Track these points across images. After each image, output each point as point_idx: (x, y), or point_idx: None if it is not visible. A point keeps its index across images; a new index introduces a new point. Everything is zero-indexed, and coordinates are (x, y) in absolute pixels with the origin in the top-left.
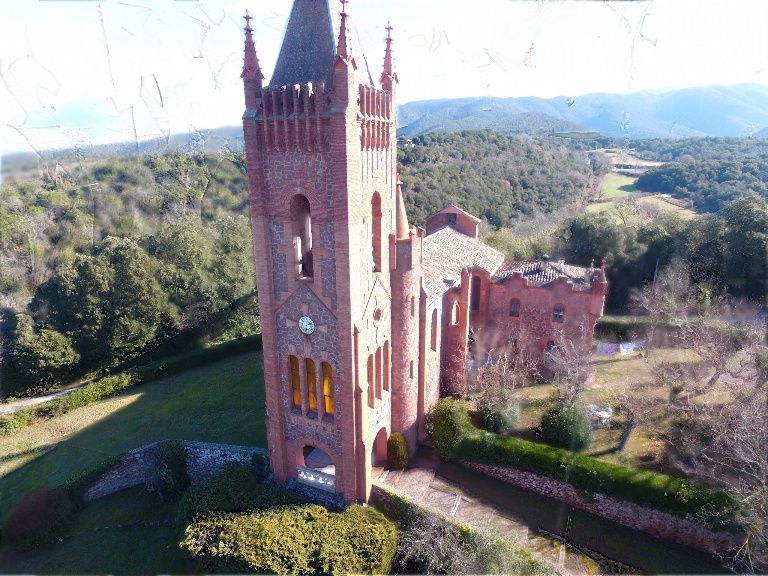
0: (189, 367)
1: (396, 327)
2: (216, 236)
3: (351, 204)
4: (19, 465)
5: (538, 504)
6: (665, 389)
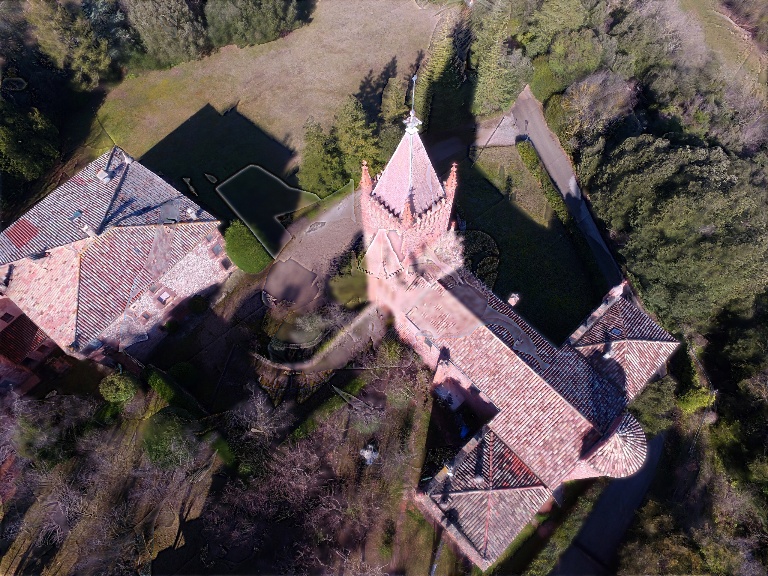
0: None
1: None
2: (708, 230)
3: None
4: (497, 186)
5: (346, 383)
6: None
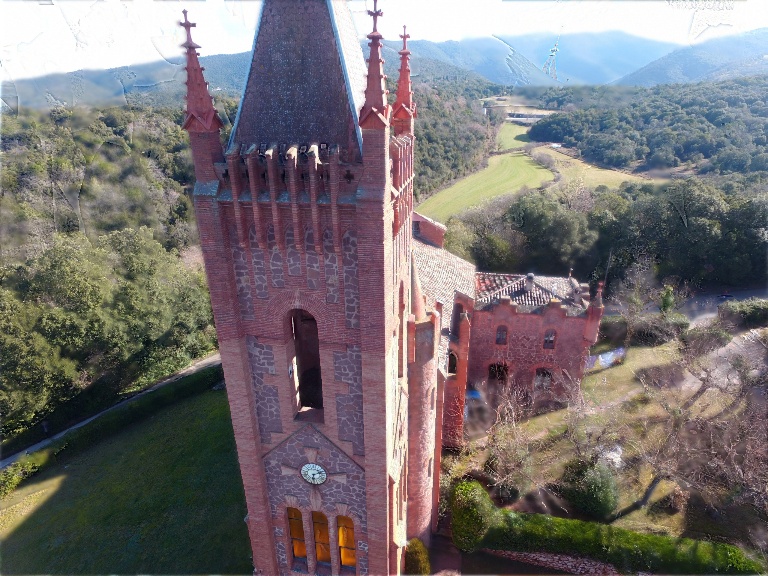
0: (103, 437)
1: (413, 427)
2: (114, 259)
3: (386, 326)
4: None
5: None
6: (654, 406)
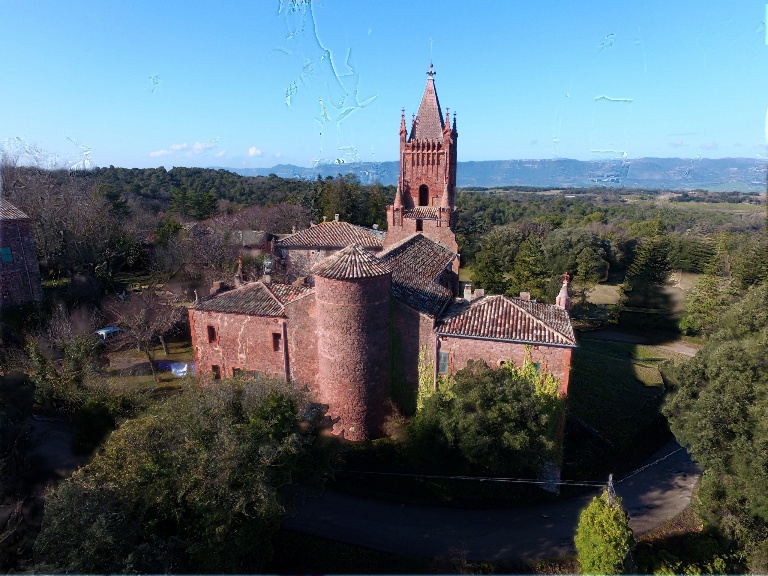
0: None
1: None
2: None
3: None
4: None
5: None
6: None
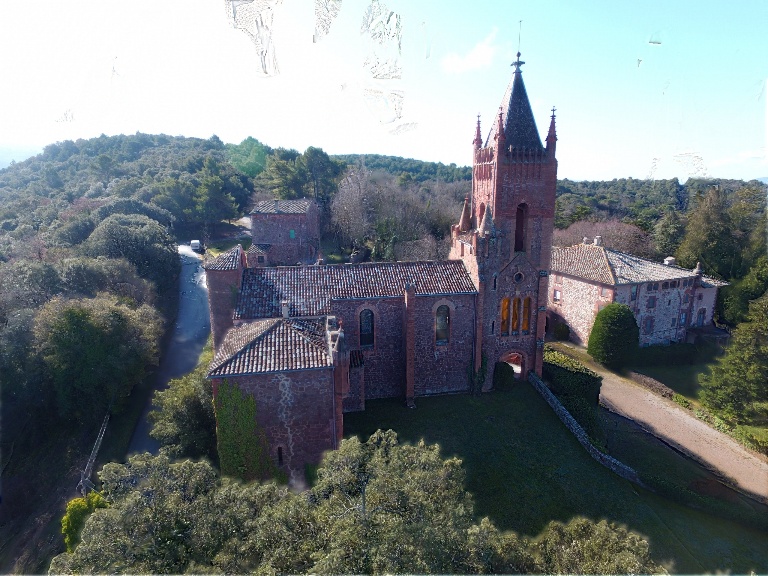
0: None
1: None
2: None
3: None
4: None
5: None
6: None
